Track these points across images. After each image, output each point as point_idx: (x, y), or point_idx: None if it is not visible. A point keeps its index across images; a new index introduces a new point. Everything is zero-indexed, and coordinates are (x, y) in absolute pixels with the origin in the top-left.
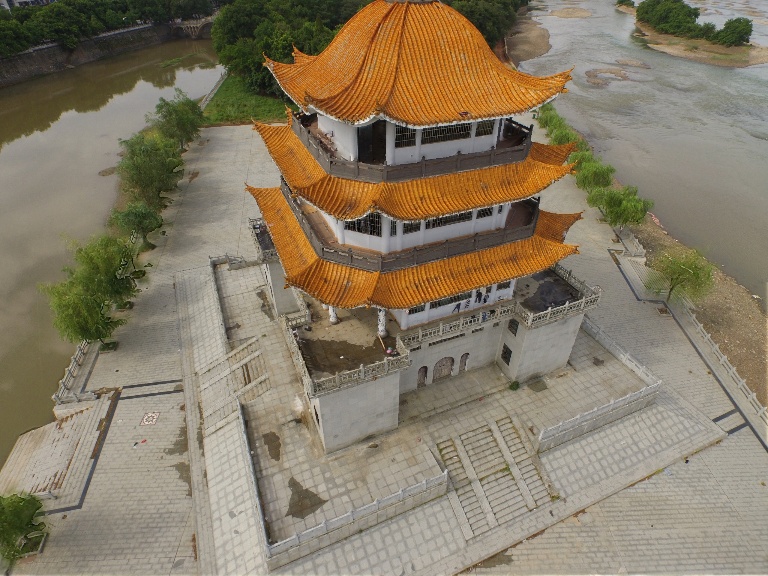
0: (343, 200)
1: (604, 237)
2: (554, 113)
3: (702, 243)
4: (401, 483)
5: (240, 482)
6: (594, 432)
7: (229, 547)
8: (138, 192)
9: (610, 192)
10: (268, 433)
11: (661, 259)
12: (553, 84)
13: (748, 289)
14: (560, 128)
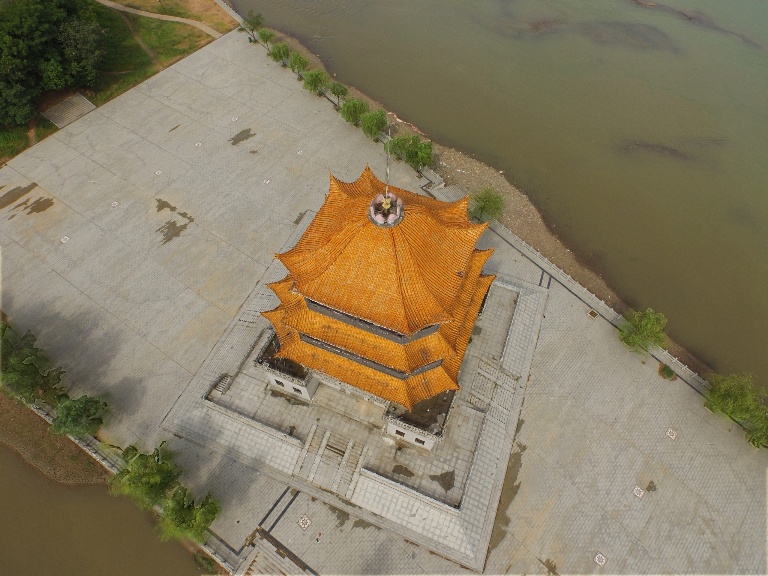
0: (417, 352)
1: (411, 176)
2: (282, 45)
3: (452, 138)
4: (472, 433)
5: (401, 500)
6: (510, 334)
7: (428, 527)
8: (35, 391)
9: (408, 150)
10: (394, 468)
11: (444, 171)
12: (463, 208)
13: (495, 168)
14: (302, 65)
